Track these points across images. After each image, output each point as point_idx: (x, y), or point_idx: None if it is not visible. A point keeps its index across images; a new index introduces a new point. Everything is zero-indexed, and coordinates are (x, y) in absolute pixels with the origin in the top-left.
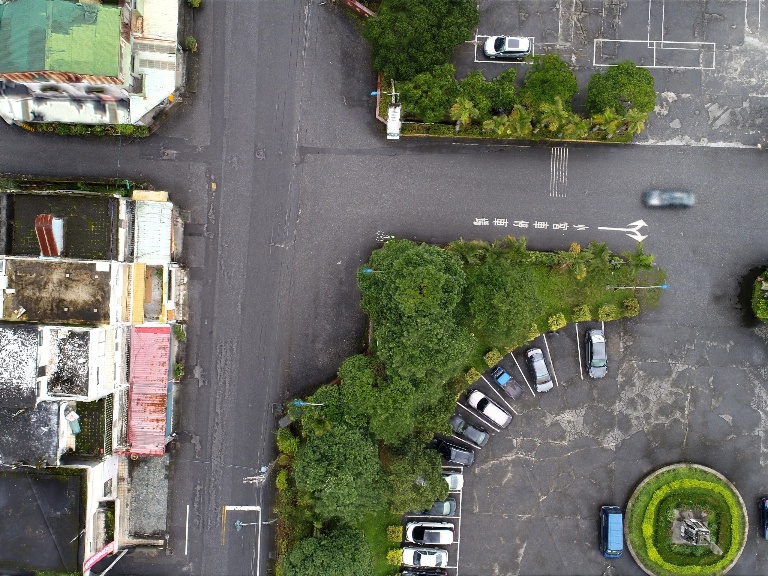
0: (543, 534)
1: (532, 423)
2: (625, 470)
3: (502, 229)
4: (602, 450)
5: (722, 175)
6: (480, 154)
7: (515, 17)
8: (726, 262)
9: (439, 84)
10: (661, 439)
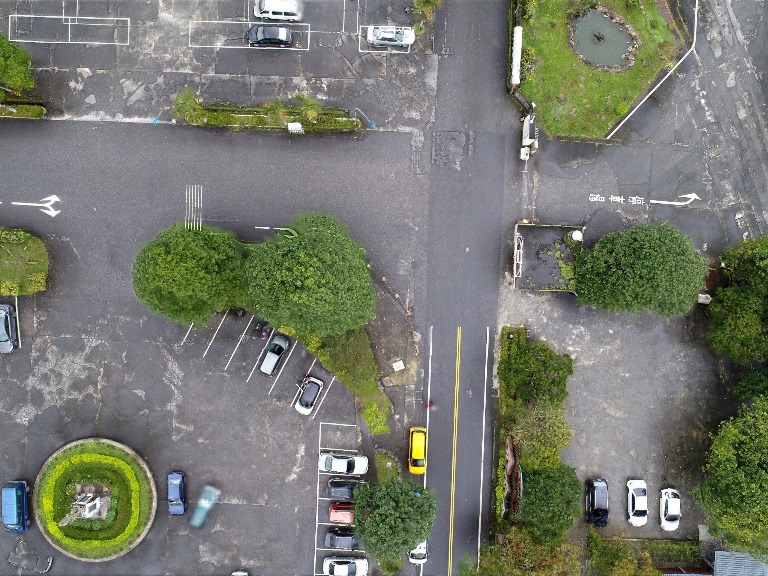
0: None
1: None
2: (38, 445)
3: None
4: (15, 425)
5: (135, 150)
6: None
7: None
8: (139, 237)
9: None
10: (73, 414)
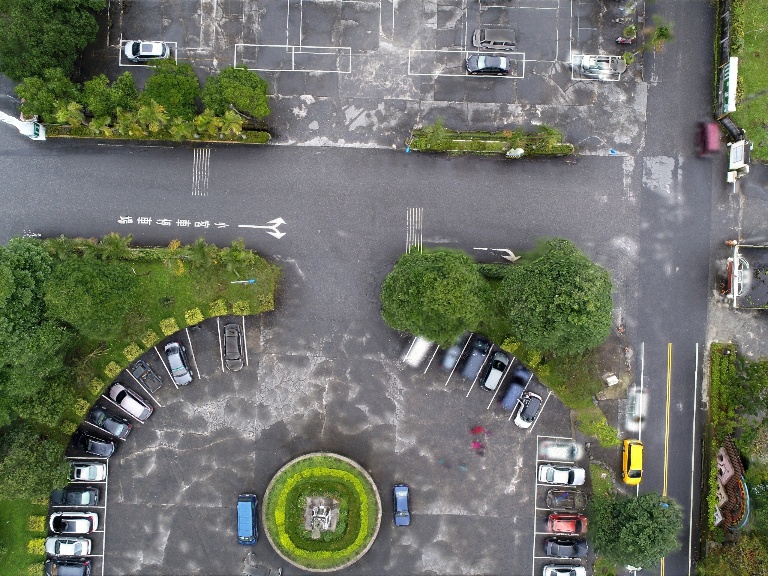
0: (186, 522)
1: (175, 415)
2: (265, 459)
3: (146, 227)
4: (243, 440)
5: (358, 174)
6: (125, 155)
7: (158, 22)
8: (362, 258)
9: (47, 87)
10: (299, 429)
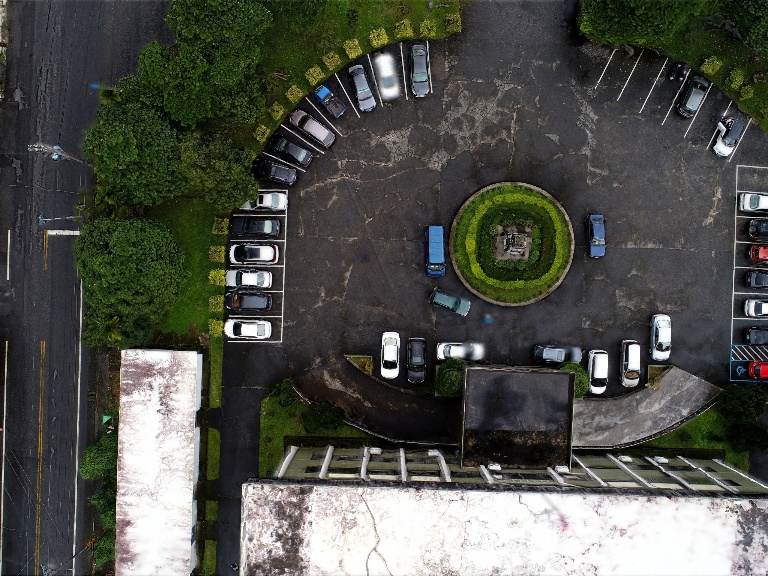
0: (369, 257)
1: (357, 145)
2: (451, 191)
3: None
4: (428, 171)
5: None
6: None
7: None
8: None
9: None
10: (487, 159)
